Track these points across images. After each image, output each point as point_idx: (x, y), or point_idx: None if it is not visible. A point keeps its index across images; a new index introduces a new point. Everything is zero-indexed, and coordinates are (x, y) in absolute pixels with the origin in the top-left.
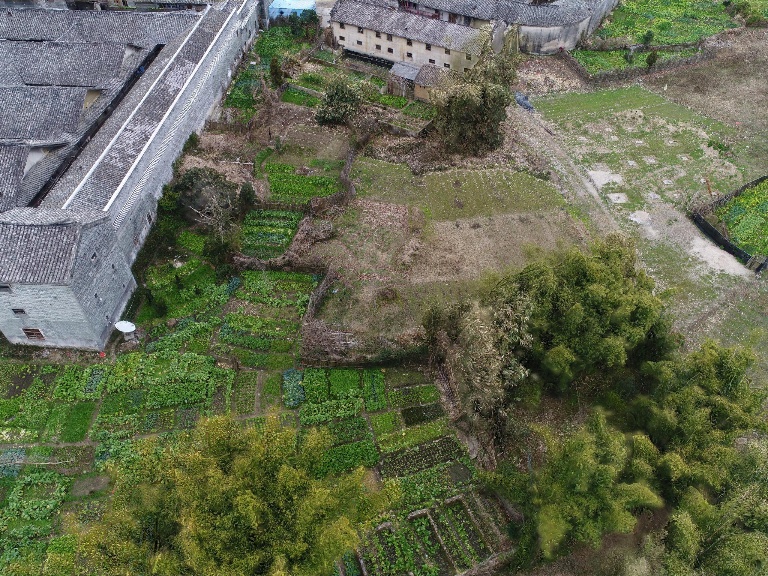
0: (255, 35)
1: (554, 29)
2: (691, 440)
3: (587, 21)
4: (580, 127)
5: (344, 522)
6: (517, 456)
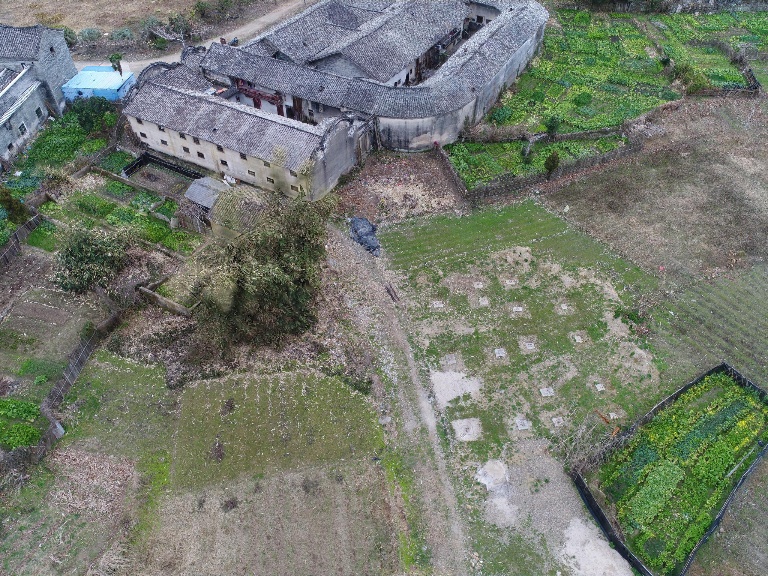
0: (38, 127)
1: (423, 121)
2: None
3: (471, 105)
4: (438, 282)
5: None
6: None
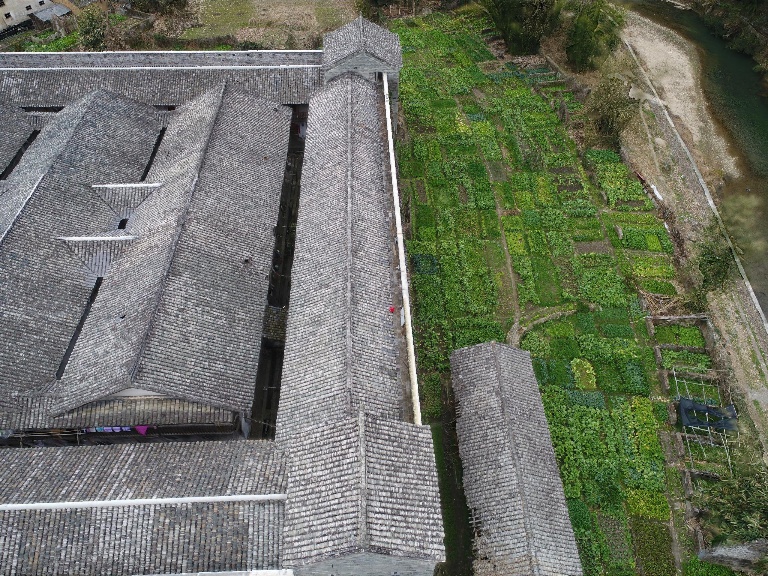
0: None
1: None
2: None
3: None
4: None
5: None
6: None
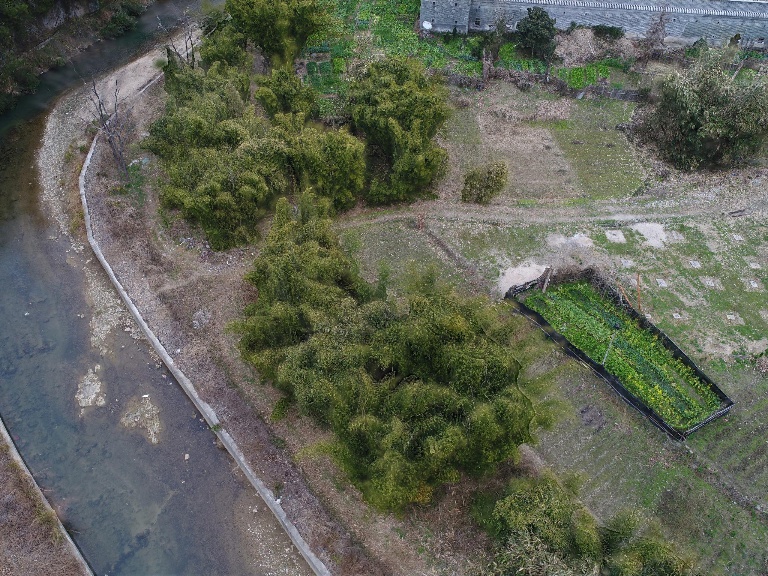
0: None
1: None
2: None
3: None
4: (766, 240)
5: None
6: None
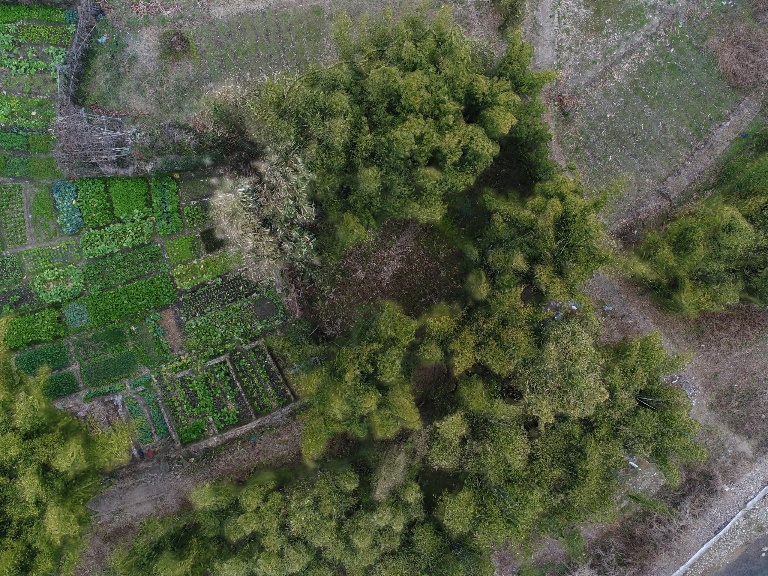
0: None
1: None
2: (496, 315)
3: None
4: None
5: (52, 520)
6: (330, 285)
